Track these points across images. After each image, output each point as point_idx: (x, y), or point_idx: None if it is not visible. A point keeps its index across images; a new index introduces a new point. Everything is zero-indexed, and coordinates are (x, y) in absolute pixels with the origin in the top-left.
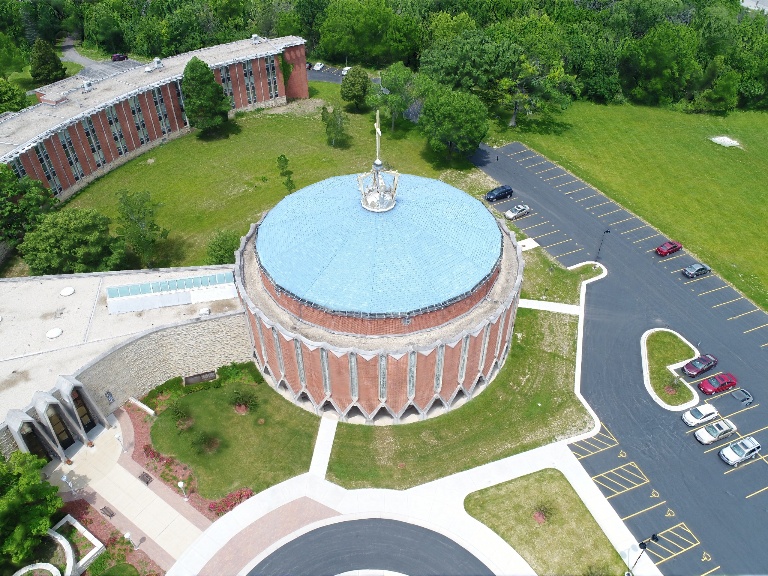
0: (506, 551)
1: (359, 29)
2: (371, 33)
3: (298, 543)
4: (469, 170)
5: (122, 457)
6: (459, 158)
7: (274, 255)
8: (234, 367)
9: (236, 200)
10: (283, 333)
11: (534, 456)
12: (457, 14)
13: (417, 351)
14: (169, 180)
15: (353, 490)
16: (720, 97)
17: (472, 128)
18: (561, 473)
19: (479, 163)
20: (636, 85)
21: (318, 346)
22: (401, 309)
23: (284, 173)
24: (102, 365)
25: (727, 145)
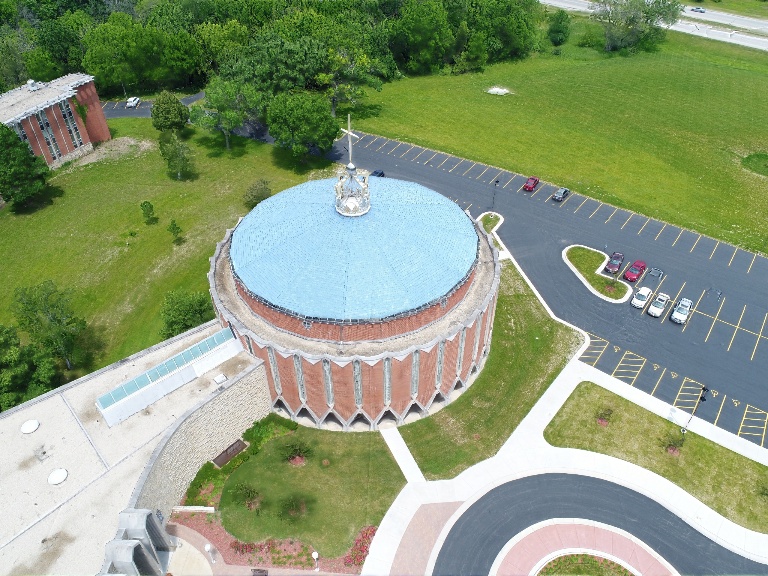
0: (602, 459)
1: (133, 54)
2: (146, 57)
3: (449, 546)
4: (330, 166)
5: (215, 569)
6: (313, 158)
7: (281, 291)
8: (258, 426)
9: (118, 265)
10: (337, 361)
11: (564, 379)
12: (219, 23)
13: (466, 326)
14: (17, 269)
15: (457, 477)
16: (476, 56)
17: (327, 125)
18: (591, 382)
19: (334, 158)
20: (408, 60)
21: (381, 358)
22: (439, 294)
23: (150, 221)
24: (148, 482)
25: (501, 94)
